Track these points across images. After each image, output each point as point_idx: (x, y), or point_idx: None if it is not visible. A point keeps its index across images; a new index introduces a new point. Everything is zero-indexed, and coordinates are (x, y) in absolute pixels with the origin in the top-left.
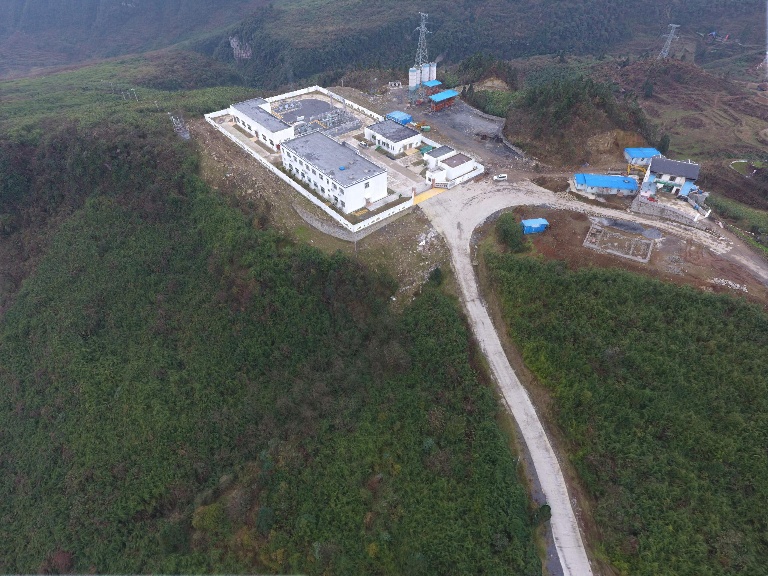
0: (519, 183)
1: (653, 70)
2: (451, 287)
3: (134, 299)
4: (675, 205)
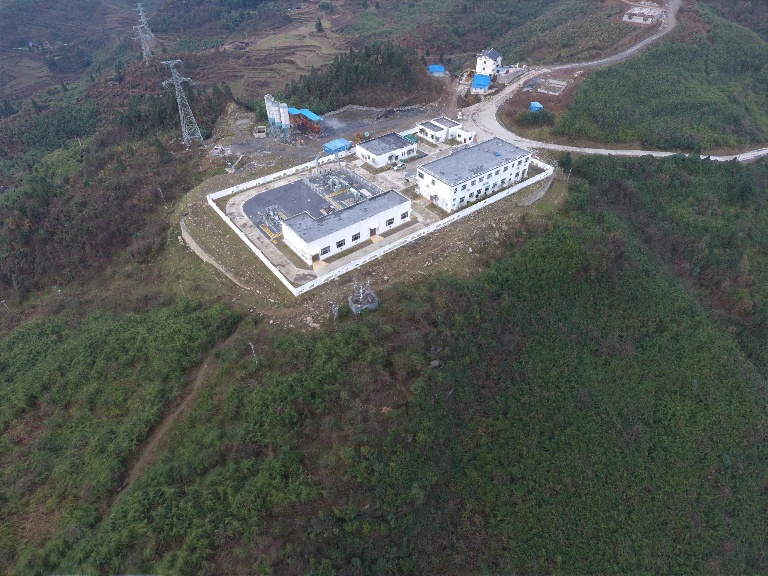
0: (465, 112)
1: (162, 69)
2: (575, 155)
3: (608, 379)
4: (509, 70)
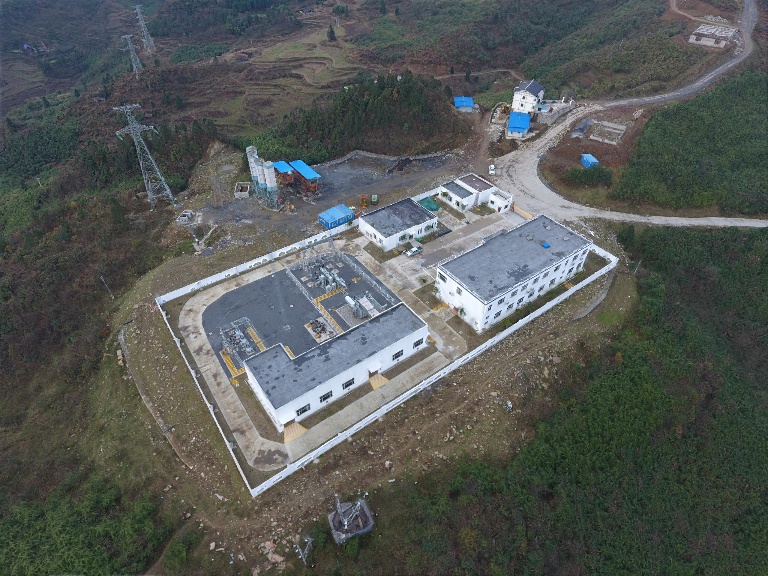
0: (498, 164)
1: (153, 84)
2: (638, 228)
3: None
4: None
